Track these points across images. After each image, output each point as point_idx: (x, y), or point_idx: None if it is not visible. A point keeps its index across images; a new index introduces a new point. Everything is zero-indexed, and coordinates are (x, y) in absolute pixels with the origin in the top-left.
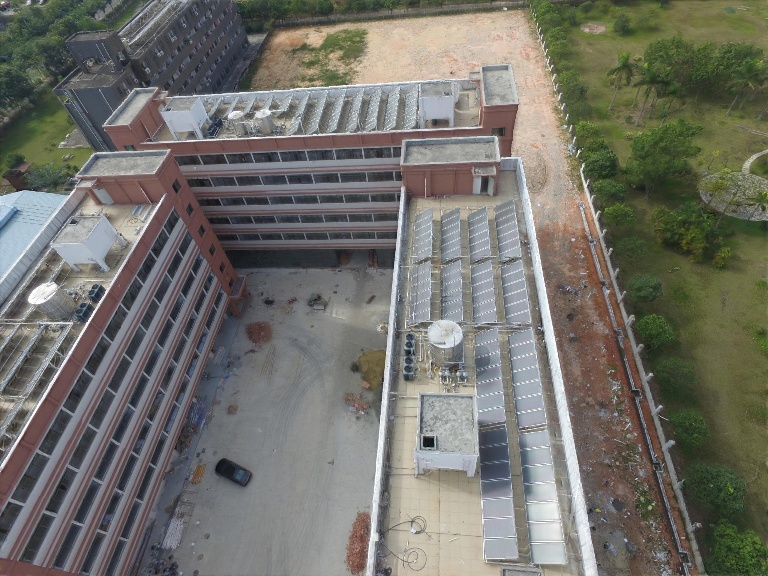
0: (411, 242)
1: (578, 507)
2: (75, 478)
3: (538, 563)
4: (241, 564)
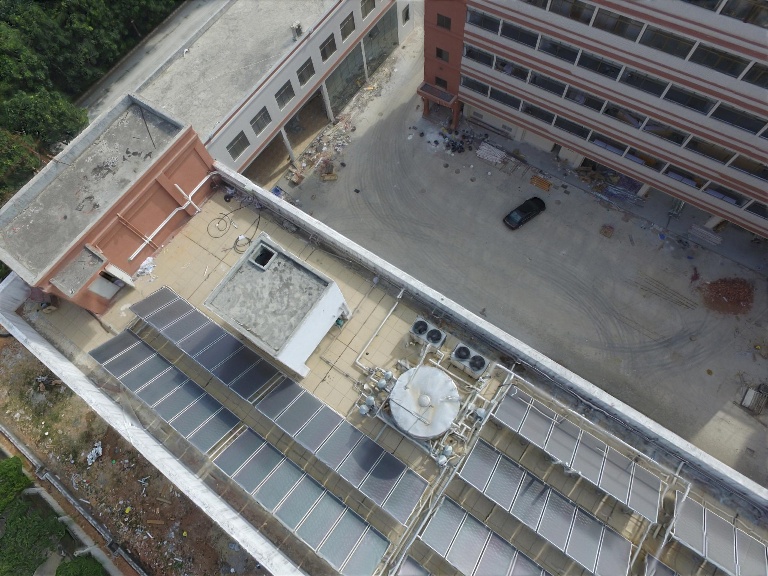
0: (760, 535)
1: (118, 416)
2: (540, 8)
3: (121, 333)
4: (432, 201)
